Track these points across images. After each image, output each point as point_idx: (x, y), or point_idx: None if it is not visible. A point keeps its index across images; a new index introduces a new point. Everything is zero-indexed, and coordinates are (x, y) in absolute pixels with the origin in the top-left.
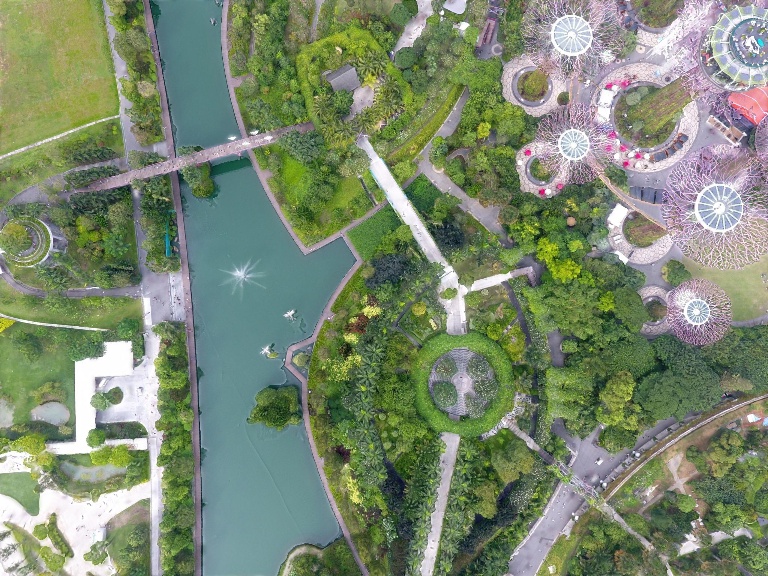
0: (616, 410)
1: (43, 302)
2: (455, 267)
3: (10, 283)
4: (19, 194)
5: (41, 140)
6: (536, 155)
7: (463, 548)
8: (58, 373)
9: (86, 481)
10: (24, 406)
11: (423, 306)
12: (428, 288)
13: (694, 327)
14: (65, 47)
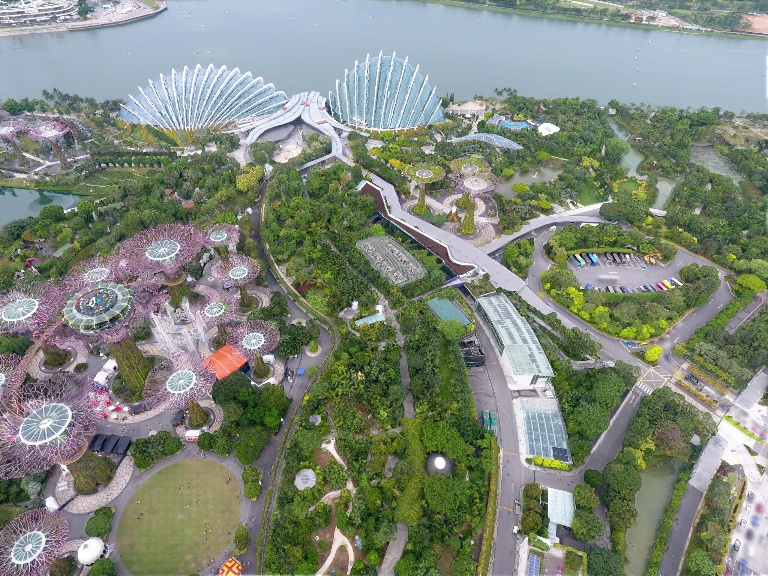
0: None
1: None
2: None
3: None
4: None
5: None
6: None
7: None
8: None
9: None
10: None
11: None
12: None
13: (15, 567)
14: None
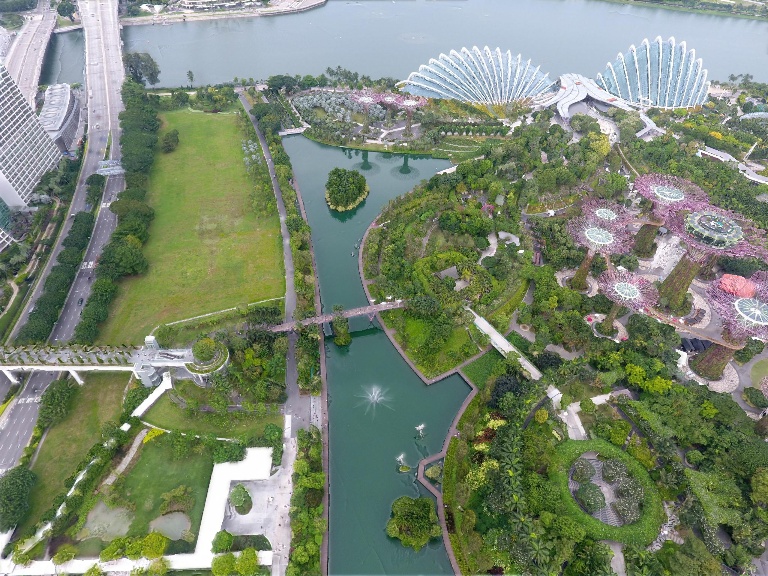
0: None
1: (209, 400)
2: (561, 390)
3: (173, 399)
4: None
5: (224, 309)
6: None
7: None
8: (192, 480)
9: None
10: (145, 515)
11: (545, 410)
12: (543, 405)
13: None
14: (254, 264)
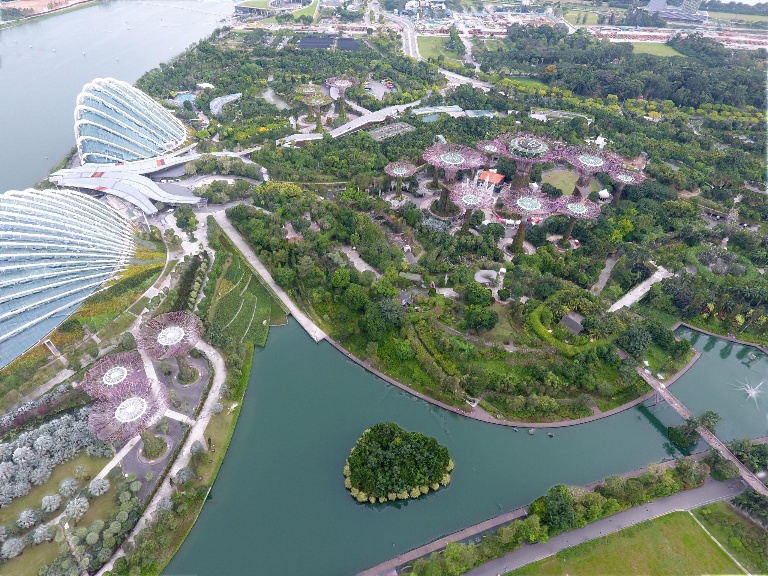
0: None
1: None
2: None
3: None
4: None
5: None
6: None
7: None
8: None
9: None
10: None
11: None
12: (675, 283)
13: (633, 179)
14: None
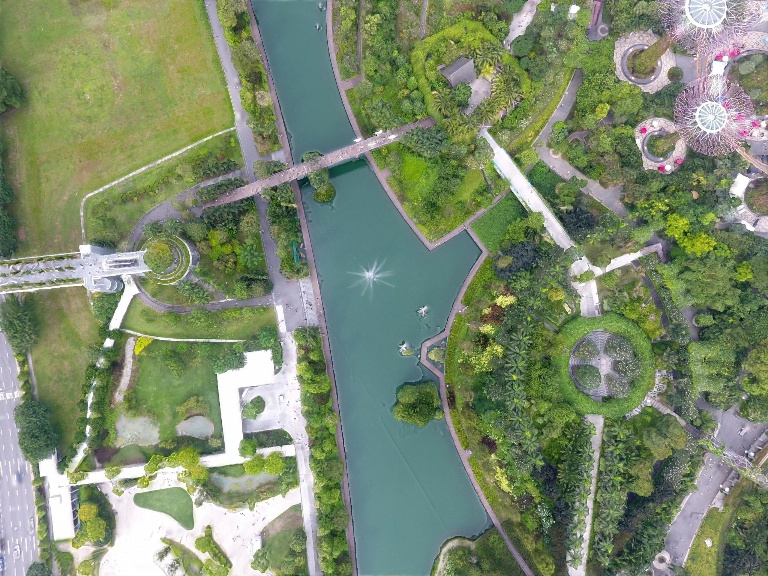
0: (765, 378)
1: (188, 317)
2: None
3: (145, 302)
4: (148, 213)
5: (161, 158)
6: (676, 130)
7: (623, 528)
8: (200, 387)
9: (236, 492)
10: (169, 422)
11: (562, 291)
12: None
13: None
14: (176, 64)
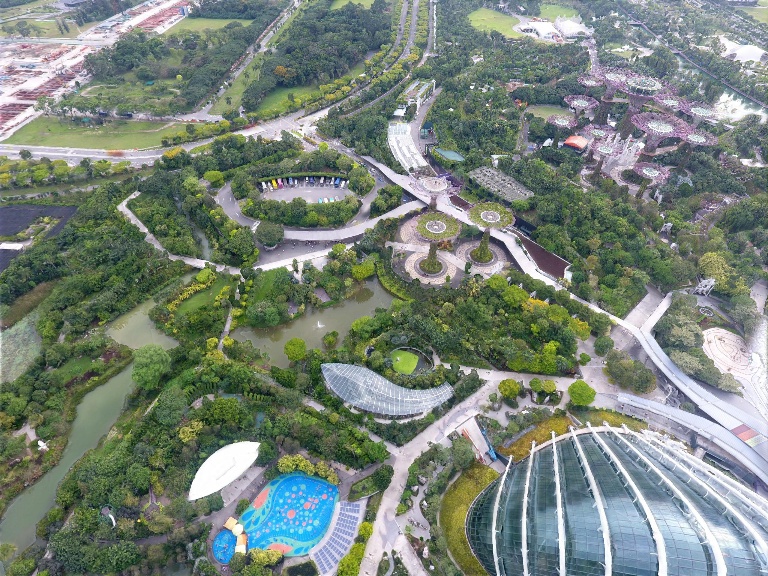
0: None
1: None
2: None
3: None
4: None
5: None
6: None
7: None
8: None
9: None
10: None
11: None
12: None
13: None
14: None
